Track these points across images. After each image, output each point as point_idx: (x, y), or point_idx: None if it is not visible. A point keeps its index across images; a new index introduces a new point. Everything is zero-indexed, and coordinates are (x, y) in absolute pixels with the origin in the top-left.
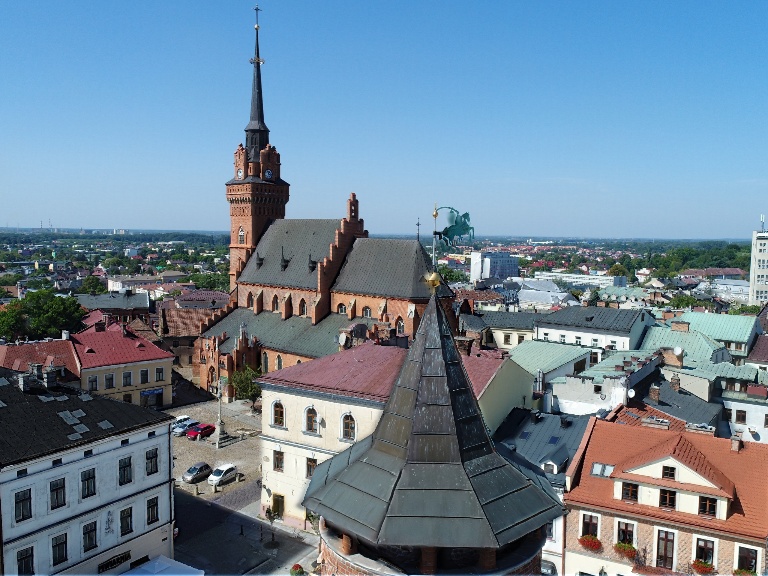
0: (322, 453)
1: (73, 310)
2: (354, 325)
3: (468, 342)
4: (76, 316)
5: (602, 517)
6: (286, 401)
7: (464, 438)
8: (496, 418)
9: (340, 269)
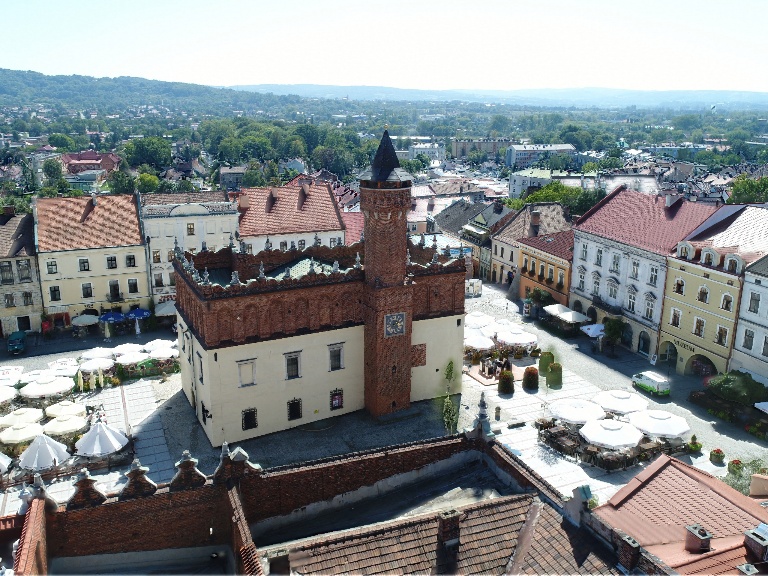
0: None
1: None
2: None
3: None
4: None
5: None
6: None
7: None
8: None
9: None
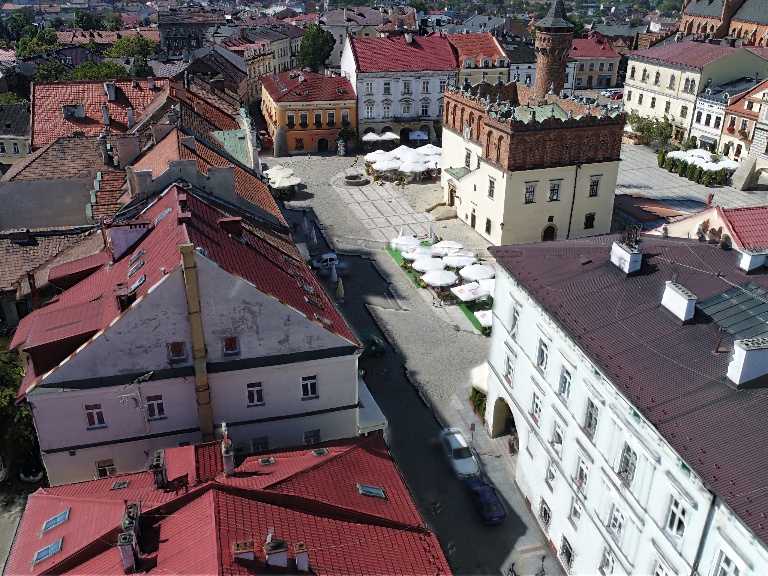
0: (646, 91)
1: (579, 29)
2: (700, 34)
3: (731, 40)
4: (580, 32)
5: (738, 117)
6: (637, 66)
7: (556, 14)
8: (725, 77)
9: (743, 4)
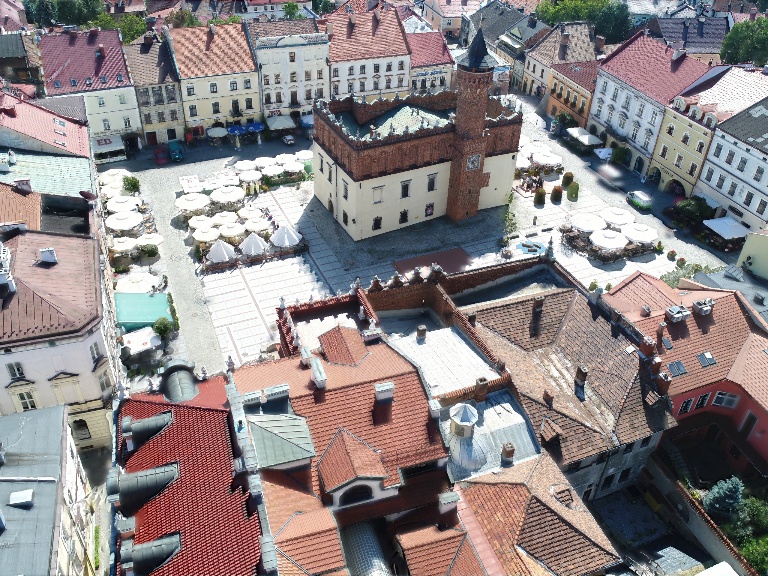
0: None
1: None
2: None
3: None
4: None
5: None
6: None
7: None
8: None
9: None
